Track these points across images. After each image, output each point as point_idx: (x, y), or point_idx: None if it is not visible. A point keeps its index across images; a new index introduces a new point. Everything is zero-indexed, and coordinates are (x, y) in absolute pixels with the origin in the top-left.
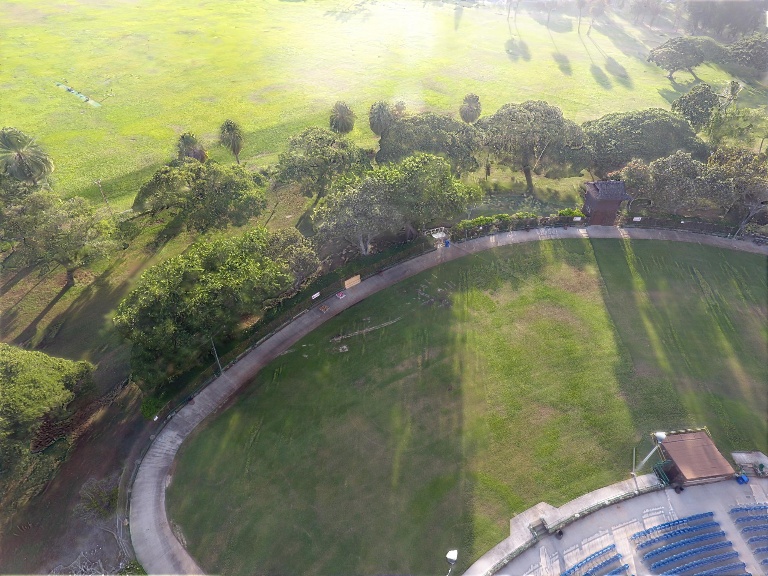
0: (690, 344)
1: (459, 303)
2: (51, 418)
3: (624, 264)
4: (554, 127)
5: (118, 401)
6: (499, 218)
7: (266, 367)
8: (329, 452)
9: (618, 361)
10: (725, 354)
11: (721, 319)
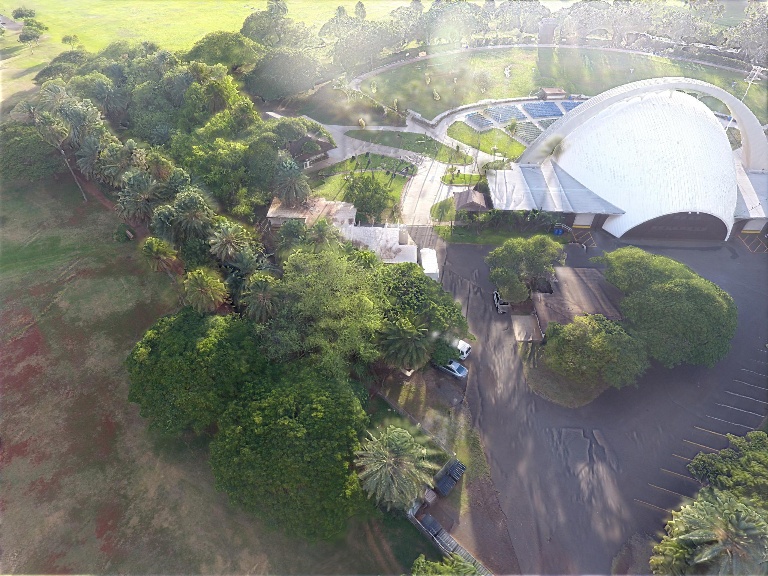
0: (570, 73)
1: (469, 61)
2: (320, 66)
3: (551, 54)
4: (533, 8)
5: (331, 82)
6: (493, 38)
7: (389, 70)
8: (414, 86)
9: (534, 74)
10: (584, 76)
11: (589, 68)
